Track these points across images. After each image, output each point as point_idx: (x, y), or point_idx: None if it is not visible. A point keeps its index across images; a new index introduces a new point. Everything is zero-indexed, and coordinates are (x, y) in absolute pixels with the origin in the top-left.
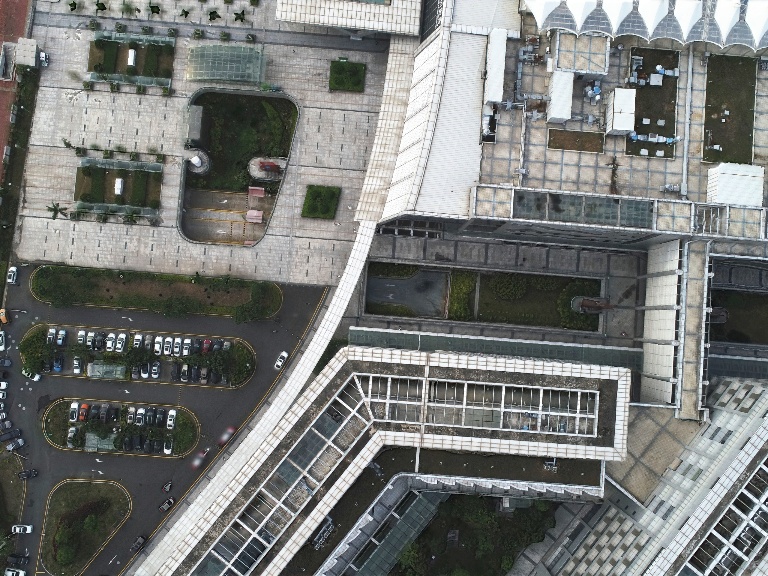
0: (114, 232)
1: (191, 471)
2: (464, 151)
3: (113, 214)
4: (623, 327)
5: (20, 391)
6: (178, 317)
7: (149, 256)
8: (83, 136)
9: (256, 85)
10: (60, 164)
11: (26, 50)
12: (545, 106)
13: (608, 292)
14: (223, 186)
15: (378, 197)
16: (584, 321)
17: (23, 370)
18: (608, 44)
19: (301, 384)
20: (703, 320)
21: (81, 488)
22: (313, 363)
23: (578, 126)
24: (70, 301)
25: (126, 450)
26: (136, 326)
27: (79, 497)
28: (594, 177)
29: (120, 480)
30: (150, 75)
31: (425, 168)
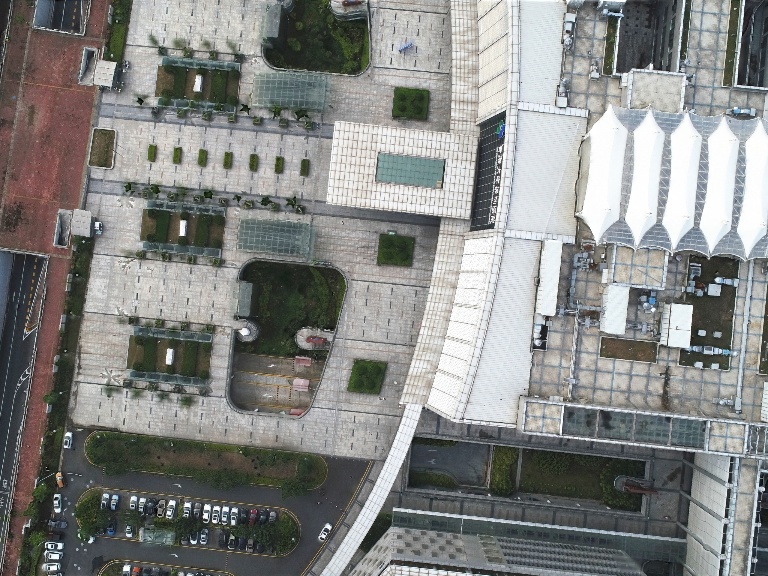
0: (165, 400)
1: None
2: (514, 359)
3: (164, 382)
4: (666, 510)
5: (75, 551)
6: (226, 490)
7: (198, 425)
8: (135, 304)
9: (305, 257)
10: (113, 332)
11: (81, 221)
12: (598, 315)
13: (653, 474)
14: (270, 351)
15: (424, 380)
16: (627, 499)
17: (79, 533)
18: (666, 258)
19: (345, 563)
20: (751, 536)
21: None
22: (357, 543)
23: (631, 334)
24: (123, 468)
25: None
26: (185, 493)
27: None
28: (646, 387)
29: None
30: (201, 246)
31: (475, 376)
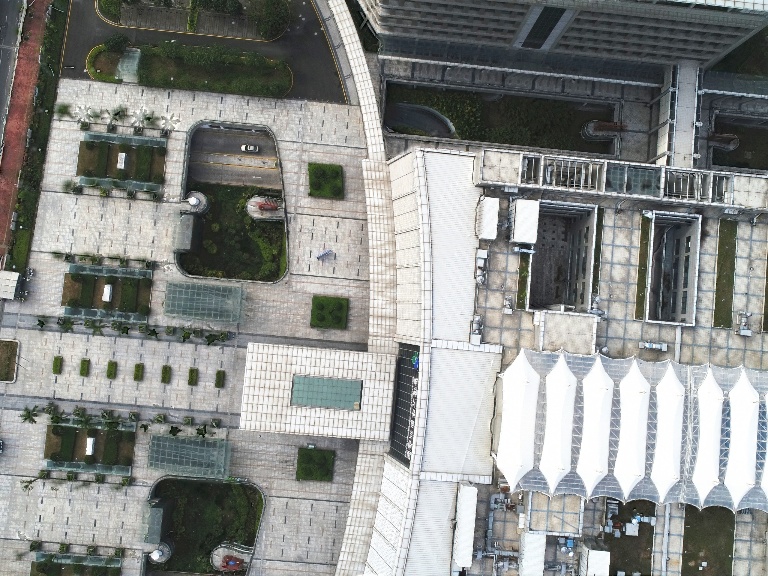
0: None
1: None
2: None
3: None
4: None
5: None
6: None
7: None
8: (38, 527)
9: (220, 473)
10: (14, 558)
11: None
12: (516, 559)
13: None
14: (185, 568)
15: None
16: None
17: None
18: (582, 504)
19: None
20: None
21: None
22: None
23: (551, 575)
24: None
25: None
26: None
27: None
28: None
29: None
30: None
31: None
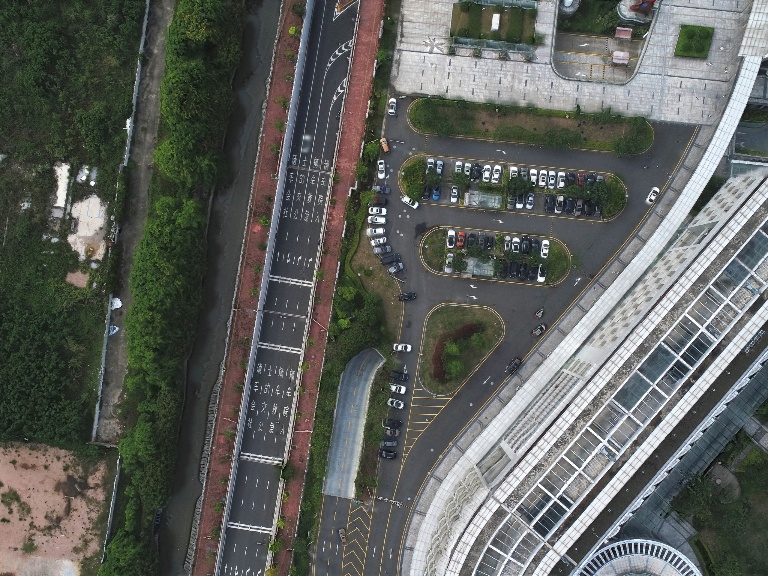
0: (489, 67)
1: (562, 299)
2: None
3: (488, 50)
4: None
5: (398, 218)
6: (559, 148)
7: (523, 91)
8: None
9: None
10: (436, 0)
11: None
12: None
13: None
14: (585, 29)
15: (764, 33)
16: None
17: (404, 197)
18: None
19: (685, 214)
20: None
21: (457, 312)
22: (697, 194)
23: None
24: (449, 132)
25: (502, 276)
26: (510, 159)
27: (455, 320)
28: None
29: (494, 305)
30: None
31: None
